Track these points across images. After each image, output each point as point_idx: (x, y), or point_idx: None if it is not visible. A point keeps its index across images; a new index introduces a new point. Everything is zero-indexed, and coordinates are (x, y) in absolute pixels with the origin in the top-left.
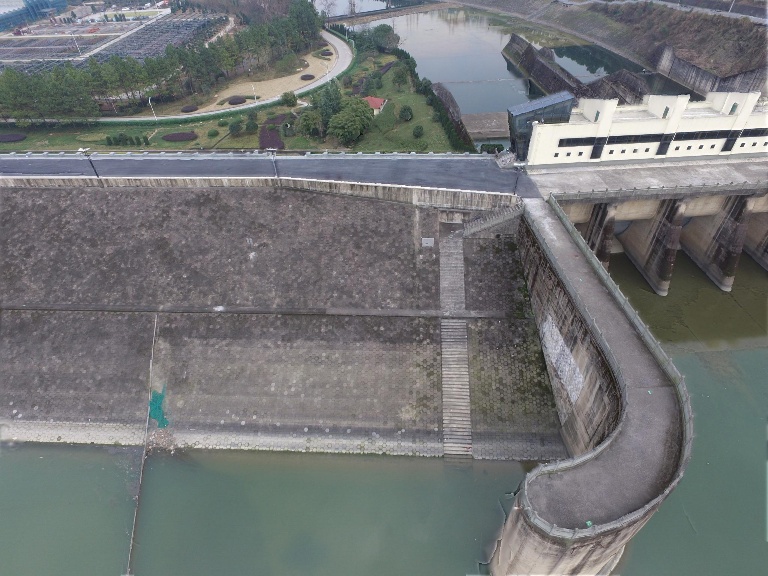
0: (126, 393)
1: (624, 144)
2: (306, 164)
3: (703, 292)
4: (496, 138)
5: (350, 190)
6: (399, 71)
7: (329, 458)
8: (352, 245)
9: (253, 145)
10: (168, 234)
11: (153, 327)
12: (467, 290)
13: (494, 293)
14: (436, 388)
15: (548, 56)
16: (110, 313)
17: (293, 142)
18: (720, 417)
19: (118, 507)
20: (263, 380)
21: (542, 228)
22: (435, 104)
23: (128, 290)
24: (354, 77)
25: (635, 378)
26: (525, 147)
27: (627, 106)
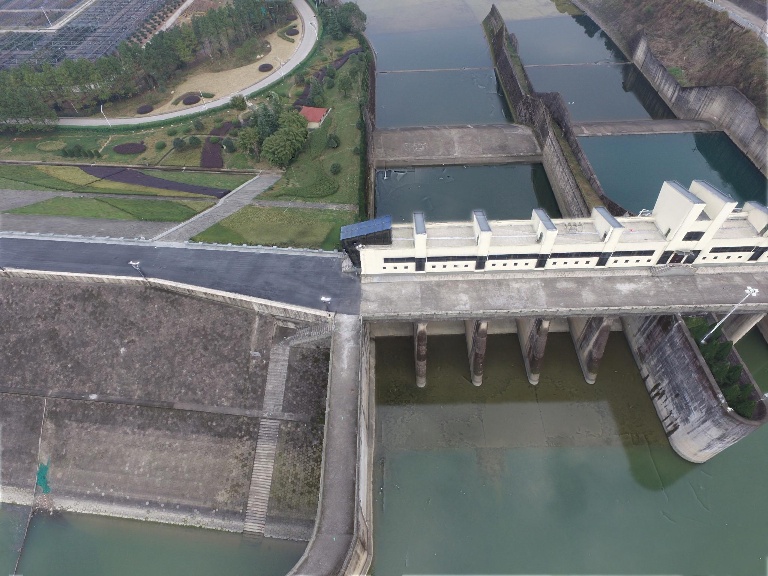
0: (21, 463)
1: (443, 262)
2: (181, 255)
3: (513, 384)
4: (421, 166)
5: (204, 295)
6: (343, 79)
7: (161, 527)
8: (201, 346)
9: (194, 163)
10: (58, 326)
11: (43, 410)
12: (285, 394)
13: (306, 399)
14: (246, 478)
15: (514, 46)
16: (12, 395)
17: (232, 159)
18: (467, 512)
19: (6, 557)
20: (120, 461)
21: (341, 354)
22: (361, 132)
23: (26, 375)
24: (310, 70)
25: (331, 525)
26: (358, 259)
27: (454, 223)
